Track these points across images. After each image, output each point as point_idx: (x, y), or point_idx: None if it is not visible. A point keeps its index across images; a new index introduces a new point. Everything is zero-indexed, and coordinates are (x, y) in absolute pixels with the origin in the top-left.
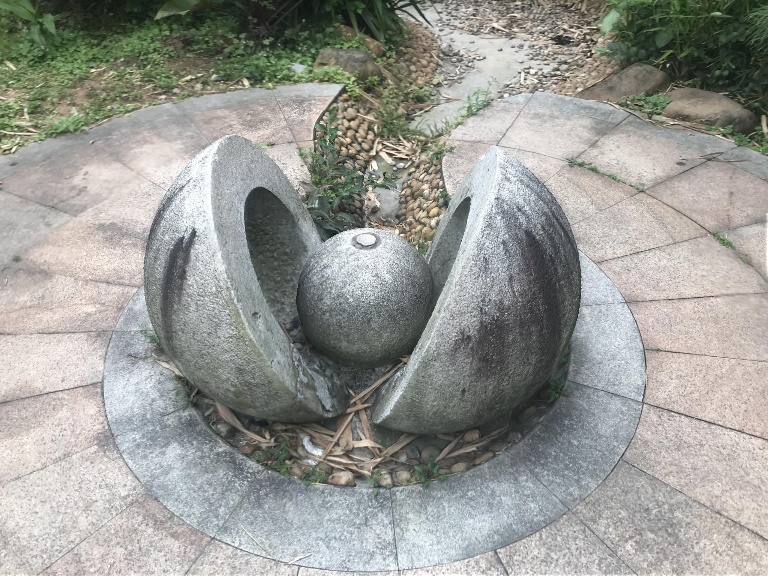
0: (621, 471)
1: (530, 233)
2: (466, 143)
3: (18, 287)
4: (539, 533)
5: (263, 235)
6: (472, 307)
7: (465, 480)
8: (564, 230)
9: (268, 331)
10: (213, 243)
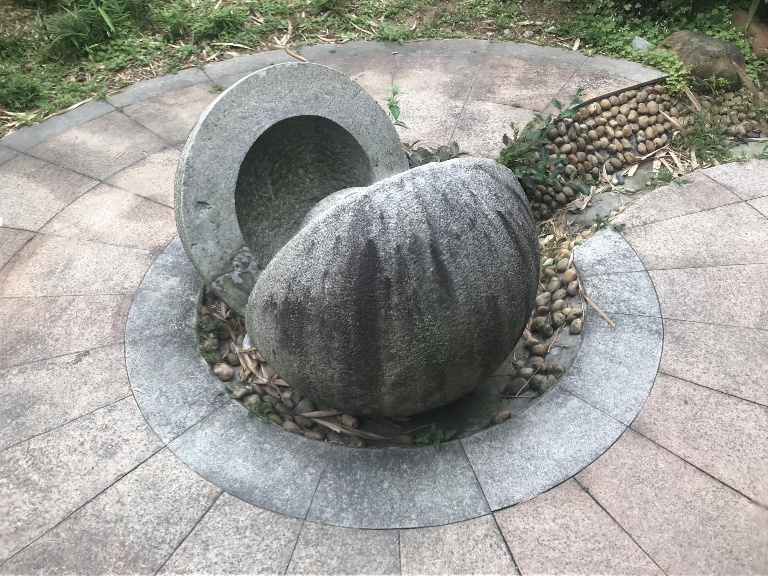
0: (383, 536)
1: (375, 244)
2: (711, 183)
3: None
4: (263, 510)
5: (342, 164)
6: (285, 279)
7: (277, 435)
8: (442, 268)
9: (212, 222)
10: (195, 134)
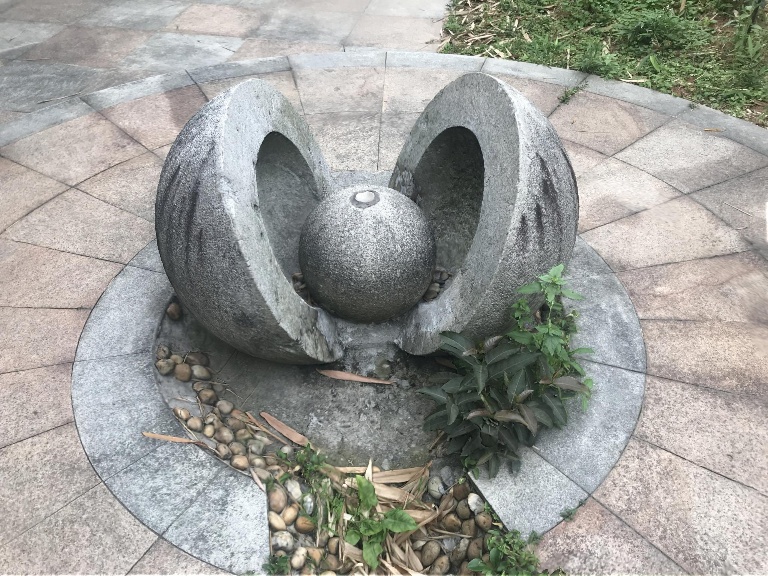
0: None
1: None
2: None
3: (767, 303)
4: None
5: None
6: None
7: None
8: None
9: None
10: None
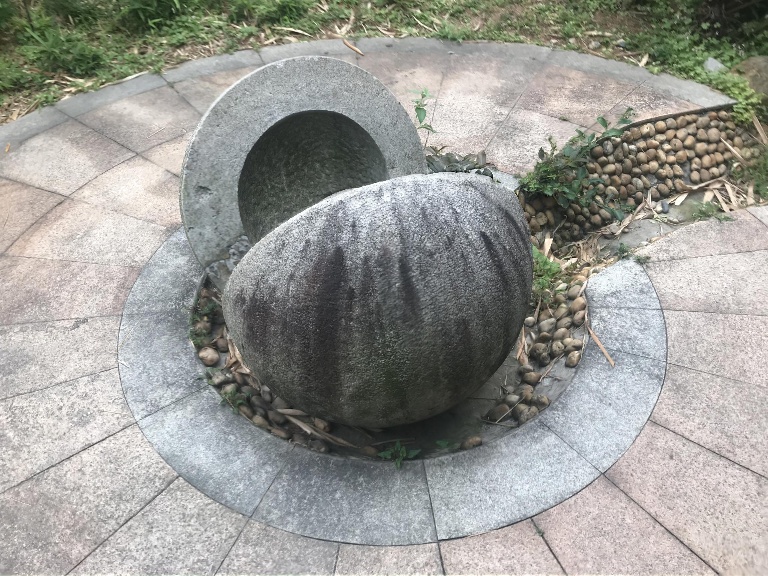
0: (323, 548)
1: (342, 252)
2: (755, 224)
3: None
4: (212, 501)
5: (359, 163)
6: (254, 275)
7: (244, 428)
8: (409, 284)
9: (212, 208)
10: (203, 119)
